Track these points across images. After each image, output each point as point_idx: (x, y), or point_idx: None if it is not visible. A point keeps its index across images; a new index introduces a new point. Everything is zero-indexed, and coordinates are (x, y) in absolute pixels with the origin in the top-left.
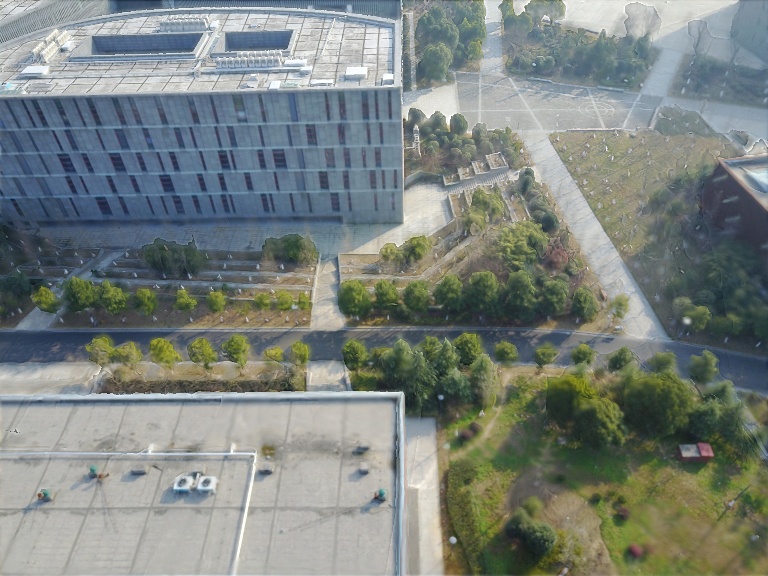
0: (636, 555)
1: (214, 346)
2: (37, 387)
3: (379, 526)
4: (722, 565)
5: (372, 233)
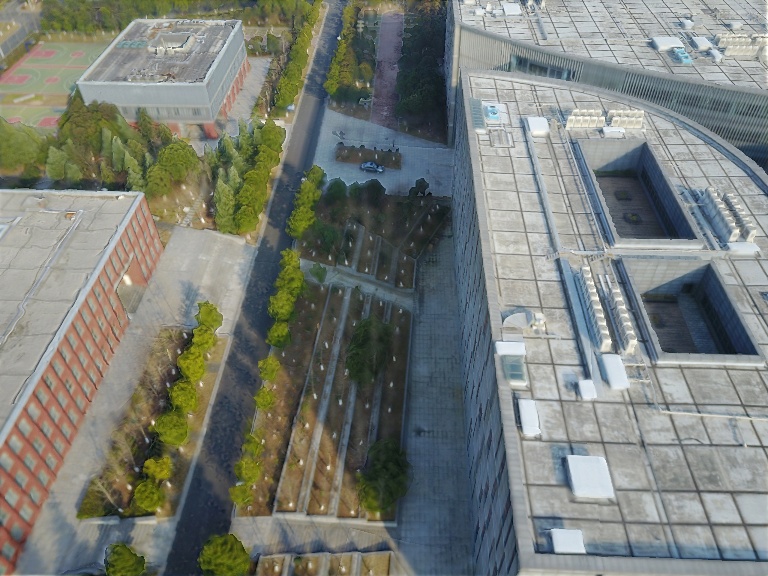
0: None
1: (230, 415)
2: (214, 290)
3: None
4: None
5: None
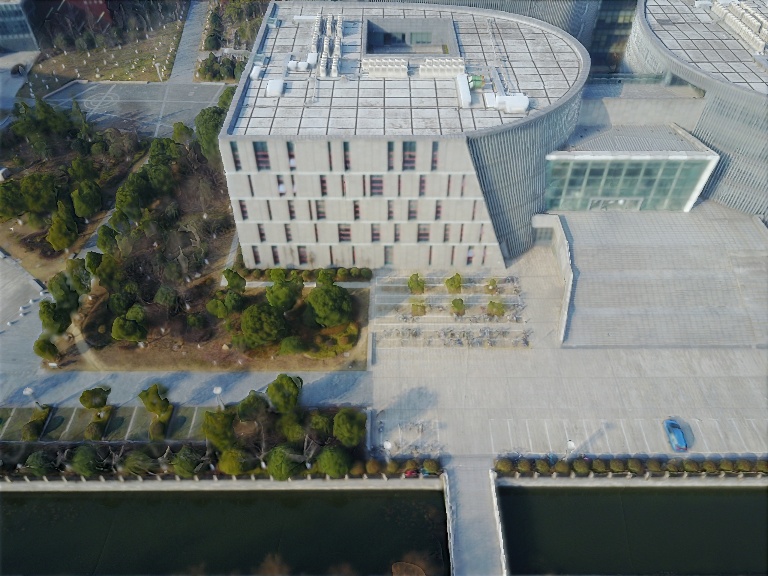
0: None
1: None
2: None
3: None
4: None
5: None
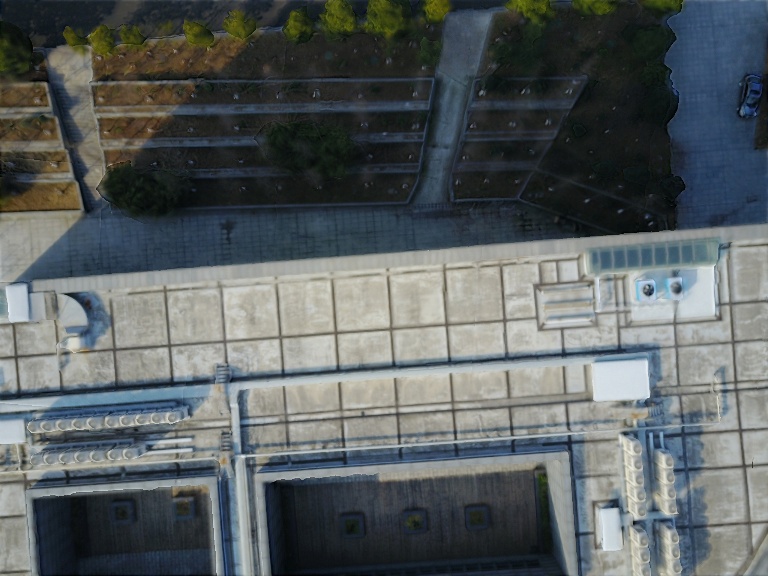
0: None
1: (207, 3)
2: None
3: None
4: None
5: (44, 272)
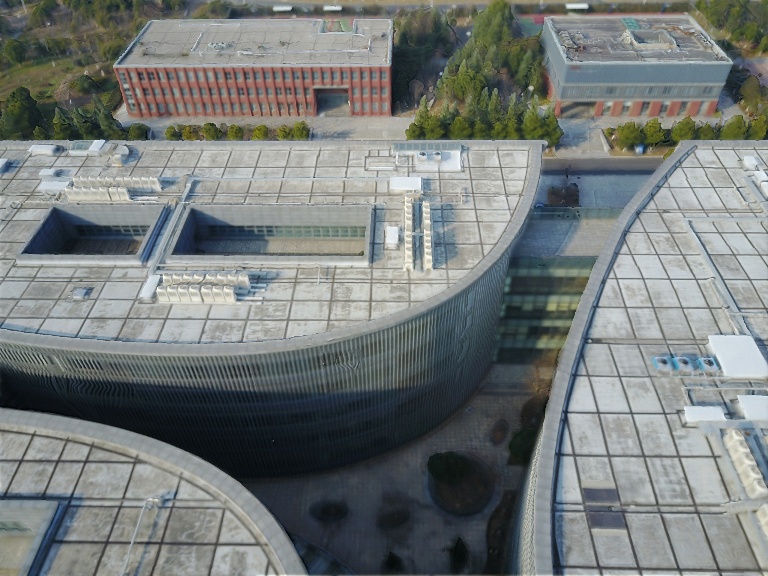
0: (50, 83)
1: None
2: None
3: (145, 41)
4: (17, 86)
5: None
